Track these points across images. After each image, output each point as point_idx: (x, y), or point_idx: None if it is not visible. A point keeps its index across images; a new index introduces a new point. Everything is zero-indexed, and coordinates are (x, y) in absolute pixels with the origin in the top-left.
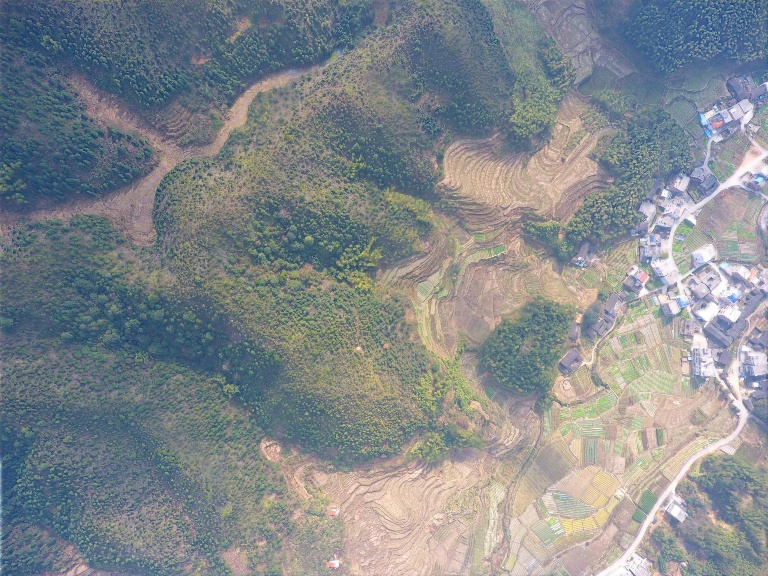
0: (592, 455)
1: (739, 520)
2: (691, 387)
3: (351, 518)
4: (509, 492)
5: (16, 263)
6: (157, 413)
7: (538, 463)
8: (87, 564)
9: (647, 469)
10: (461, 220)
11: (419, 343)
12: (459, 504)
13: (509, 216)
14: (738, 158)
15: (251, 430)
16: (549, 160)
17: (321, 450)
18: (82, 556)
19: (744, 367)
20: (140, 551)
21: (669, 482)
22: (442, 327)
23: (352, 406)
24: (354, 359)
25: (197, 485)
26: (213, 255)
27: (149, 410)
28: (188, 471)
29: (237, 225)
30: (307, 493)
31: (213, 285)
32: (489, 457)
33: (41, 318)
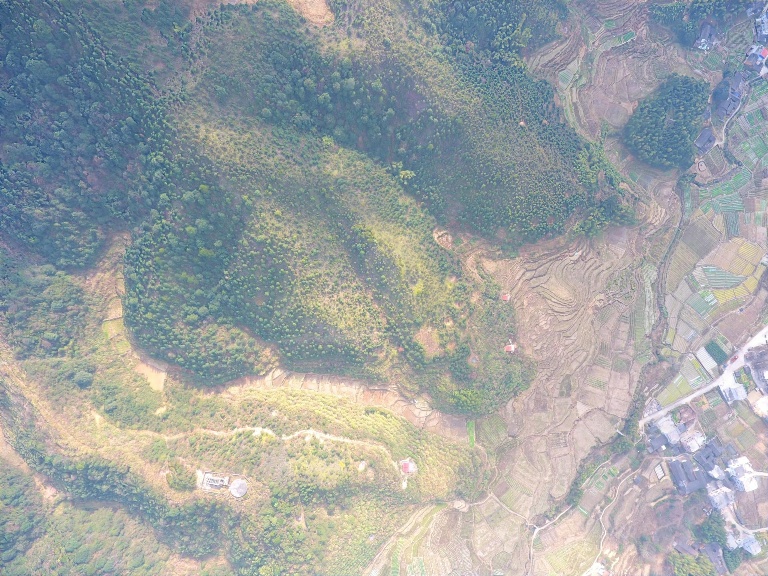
0: (735, 228)
1: None
2: None
3: (521, 304)
4: (660, 273)
5: (223, 32)
6: (351, 190)
7: (685, 241)
8: (283, 367)
9: None
10: (592, 8)
11: (569, 126)
12: (618, 283)
13: None
14: None
15: (424, 219)
16: None
17: (493, 231)
18: (281, 355)
19: None
20: (343, 333)
21: None
22: (584, 114)
23: (525, 175)
24: (521, 131)
25: (392, 261)
26: (396, 20)
27: (345, 185)
28: (383, 247)
29: None
30: (481, 278)
31: (400, 48)
32: (639, 238)
33: (246, 91)
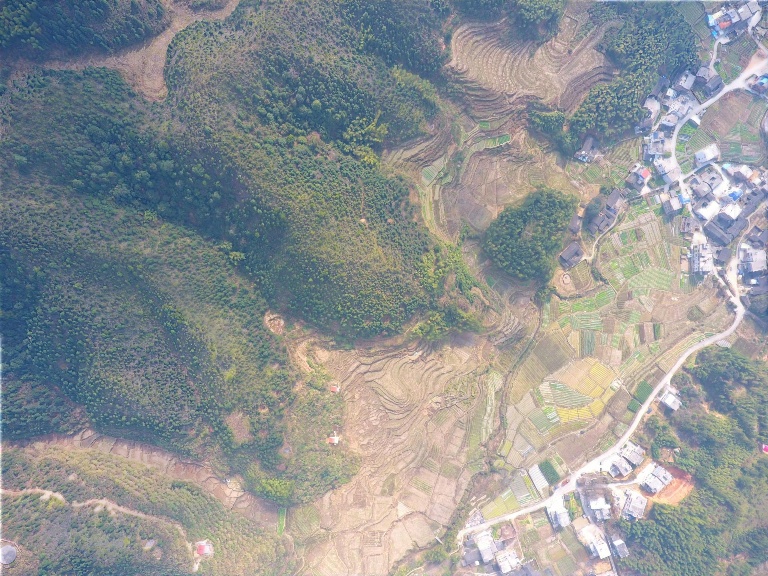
0: (589, 347)
1: (732, 408)
2: (689, 284)
3: (351, 396)
4: (507, 381)
5: (30, 102)
6: (165, 269)
7: (536, 353)
8: (93, 429)
9: (643, 362)
10: (467, 107)
11: (422, 225)
12: (457, 388)
13: (514, 104)
14: (744, 60)
15: (256, 301)
16: (556, 52)
17: (324, 323)
18: (89, 418)
19: (743, 264)
20: (146, 409)
21: (665, 374)
22: (445, 213)
23: (355, 275)
24: (358, 229)
25: (202, 344)
26: (223, 108)
27: (157, 264)
28: (194, 330)
29: (247, 80)
30: (309, 367)
31: (222, 137)
32: (488, 345)
33: (54, 162)
